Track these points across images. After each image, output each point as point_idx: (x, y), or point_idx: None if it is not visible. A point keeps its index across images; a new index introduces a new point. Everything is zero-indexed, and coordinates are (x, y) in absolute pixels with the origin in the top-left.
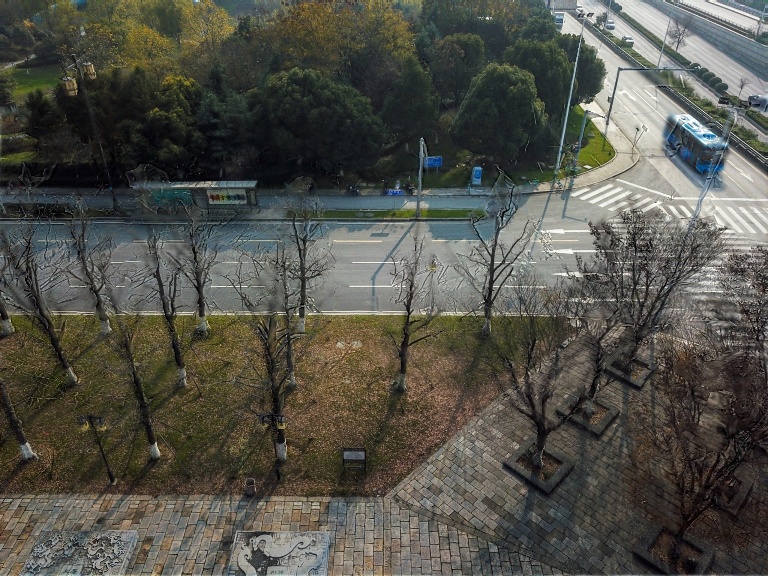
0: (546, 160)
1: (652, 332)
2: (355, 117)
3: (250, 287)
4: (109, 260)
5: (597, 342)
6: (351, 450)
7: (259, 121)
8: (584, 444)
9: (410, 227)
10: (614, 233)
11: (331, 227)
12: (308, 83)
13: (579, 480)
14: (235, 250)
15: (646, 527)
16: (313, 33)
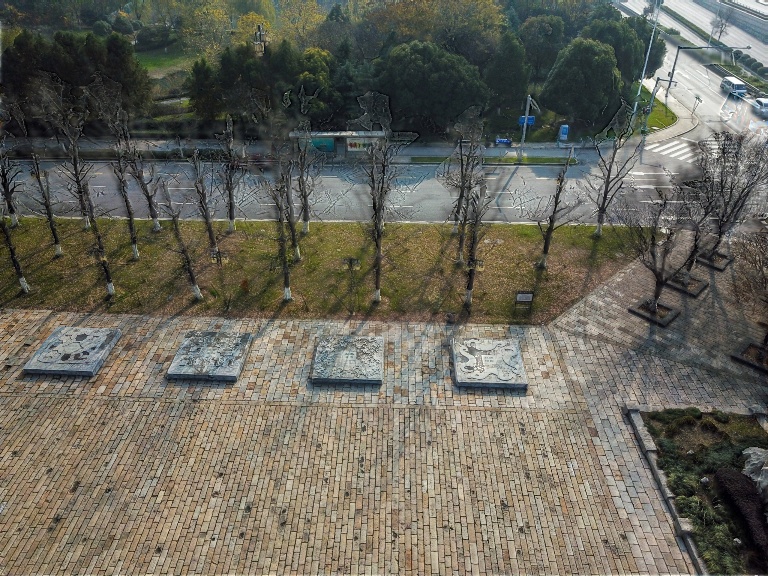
0: None
1: (733, 226)
2: (467, 81)
3: (401, 207)
4: None
5: (696, 226)
6: (523, 293)
7: (385, 84)
8: (685, 301)
9: (515, 169)
10: (708, 149)
11: None
12: (427, 53)
13: (685, 320)
14: None
15: (738, 344)
16: (425, 13)
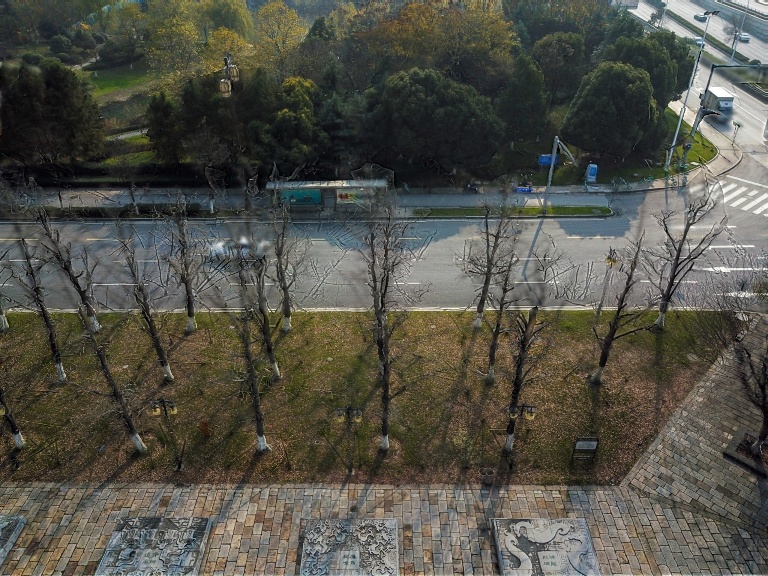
0: (652, 157)
1: None
2: (478, 116)
3: (406, 284)
4: (303, 257)
5: None
6: (584, 440)
7: (380, 121)
8: None
9: (540, 224)
10: None
11: (462, 225)
12: (429, 83)
13: None
14: (378, 248)
15: None
16: (425, 33)
